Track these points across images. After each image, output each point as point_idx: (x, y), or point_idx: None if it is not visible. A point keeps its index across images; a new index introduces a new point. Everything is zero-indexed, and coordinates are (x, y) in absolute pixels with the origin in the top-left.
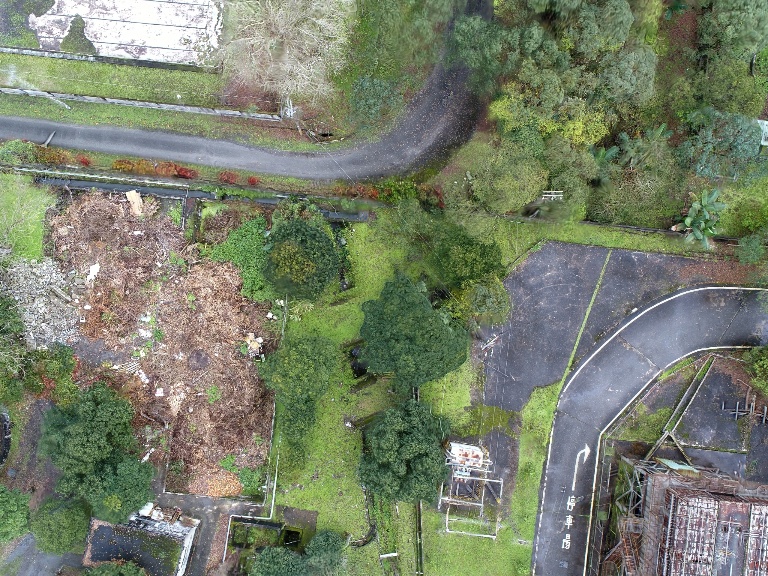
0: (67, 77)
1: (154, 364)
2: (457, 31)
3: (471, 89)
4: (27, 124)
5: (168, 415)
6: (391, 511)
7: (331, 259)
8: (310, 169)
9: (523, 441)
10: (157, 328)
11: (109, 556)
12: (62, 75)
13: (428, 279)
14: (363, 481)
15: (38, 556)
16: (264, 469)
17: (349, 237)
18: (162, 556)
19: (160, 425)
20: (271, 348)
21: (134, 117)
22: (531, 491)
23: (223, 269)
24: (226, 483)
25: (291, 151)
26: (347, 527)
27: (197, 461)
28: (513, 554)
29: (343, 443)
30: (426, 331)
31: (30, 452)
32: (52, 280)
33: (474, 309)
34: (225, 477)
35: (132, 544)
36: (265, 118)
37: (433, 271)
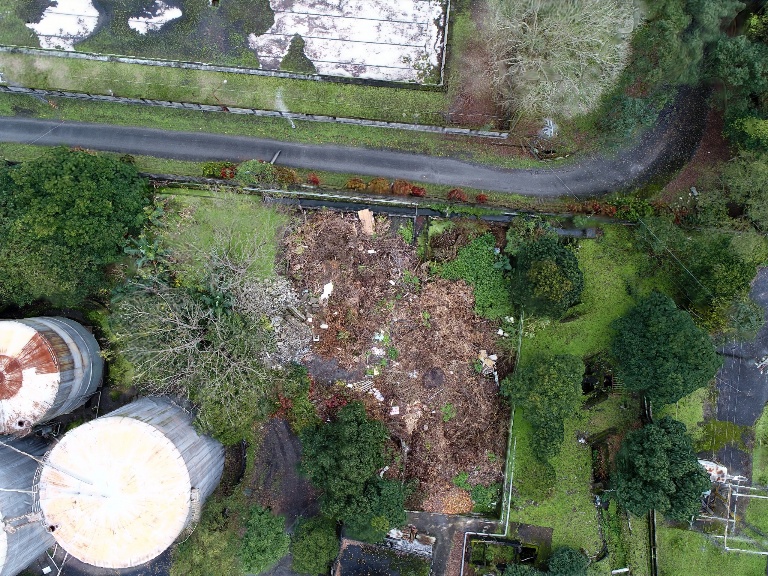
0: (293, 96)
1: (391, 382)
2: (720, 50)
3: (695, 105)
4: (252, 143)
5: (404, 433)
6: (622, 527)
7: (579, 277)
8: (534, 186)
9: (756, 456)
10: (391, 346)
11: (358, 575)
12: (288, 94)
13: (660, 295)
14: (620, 498)
15: (275, 575)
16: (497, 486)
17: (574, 253)
18: (411, 575)
19: (394, 443)
20: (504, 365)
21: (358, 136)
22: (764, 505)
23: (457, 287)
24: (459, 500)
25: (515, 168)
26: (582, 543)
27: (431, 479)
28: (747, 568)
29: (576, 459)
30: (698, 349)
31: (265, 471)
32: (288, 299)
33: (729, 326)
34: (458, 494)
35: (381, 563)
36: (490, 136)
37: (669, 287)
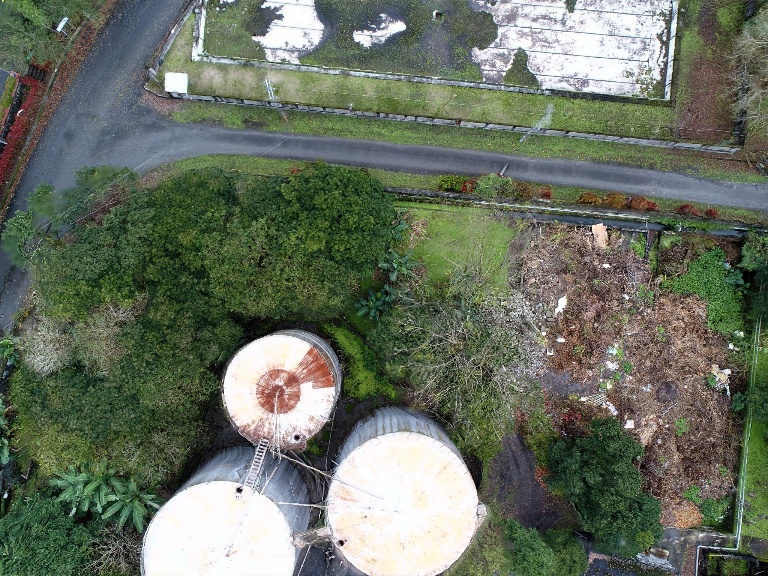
0: (522, 110)
1: (627, 396)
2: None
3: None
4: (480, 157)
5: None
6: None
7: None
8: (760, 201)
9: None
10: (625, 360)
11: None
12: (517, 109)
13: None
14: None
15: None
16: (729, 500)
17: None
18: None
19: None
20: (737, 380)
21: (585, 150)
22: None
23: (692, 301)
24: (690, 514)
25: (741, 183)
26: None
27: (663, 492)
28: None
29: None
30: None
31: (499, 484)
32: (525, 313)
33: None
34: (689, 508)
35: None
36: (717, 151)
37: None
